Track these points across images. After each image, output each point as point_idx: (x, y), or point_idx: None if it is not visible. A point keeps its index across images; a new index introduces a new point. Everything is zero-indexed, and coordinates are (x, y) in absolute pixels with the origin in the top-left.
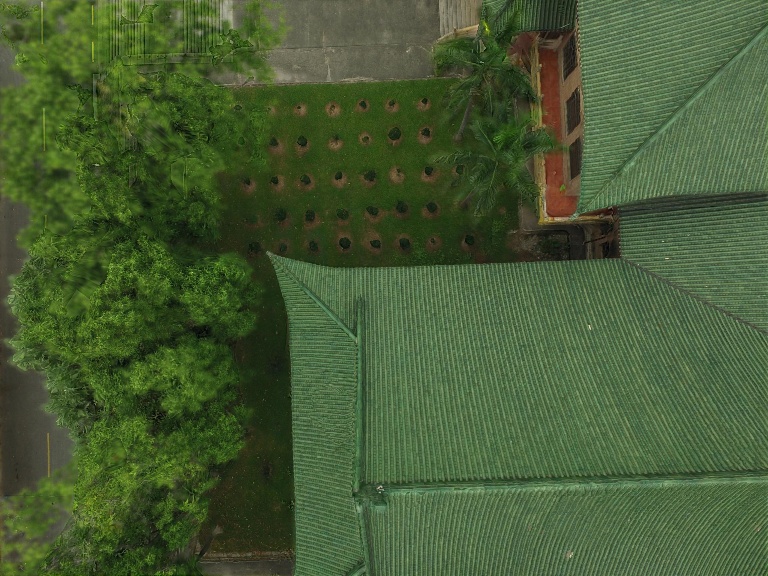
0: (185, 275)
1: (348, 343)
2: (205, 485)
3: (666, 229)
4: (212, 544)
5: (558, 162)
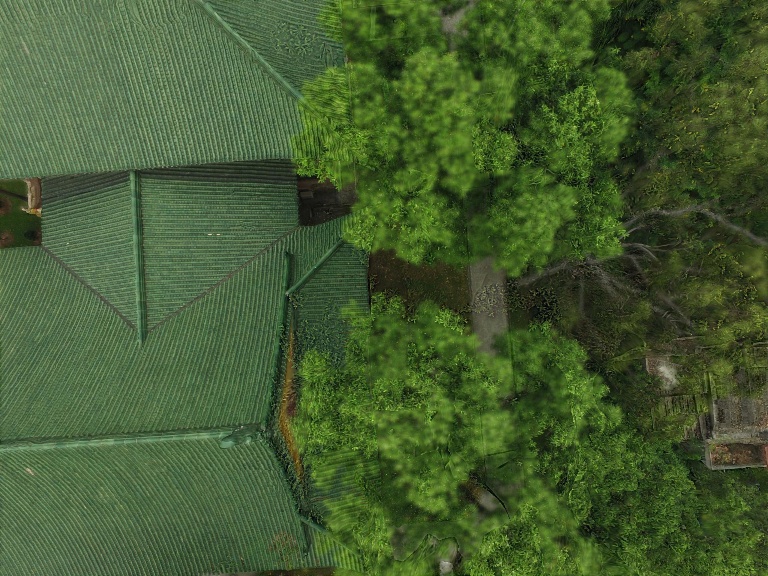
0: None
1: None
2: None
3: (67, 215)
4: None
5: None
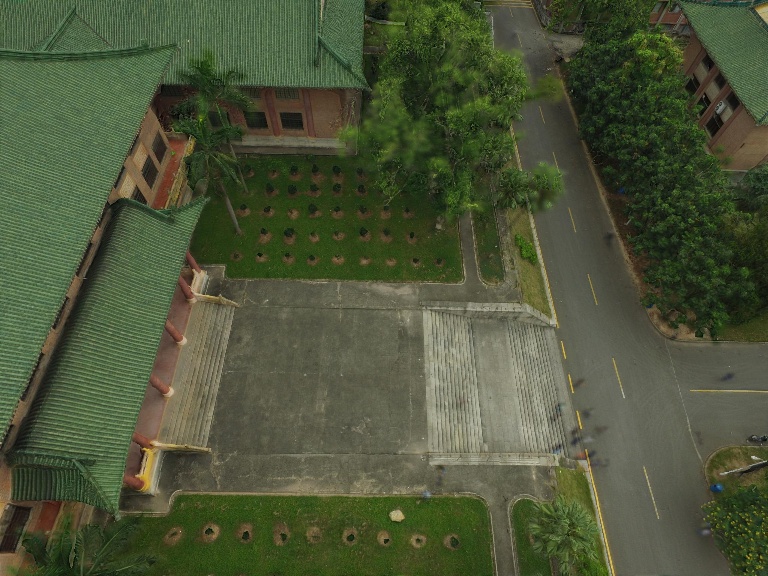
0: (410, 50)
1: None
2: (408, 12)
3: None
4: None
5: (171, 166)
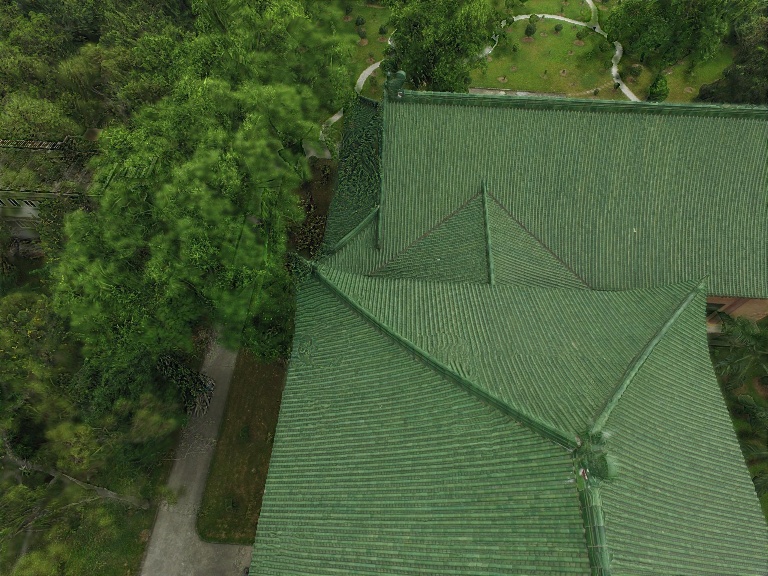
0: None
1: None
2: None
3: None
4: None
5: None
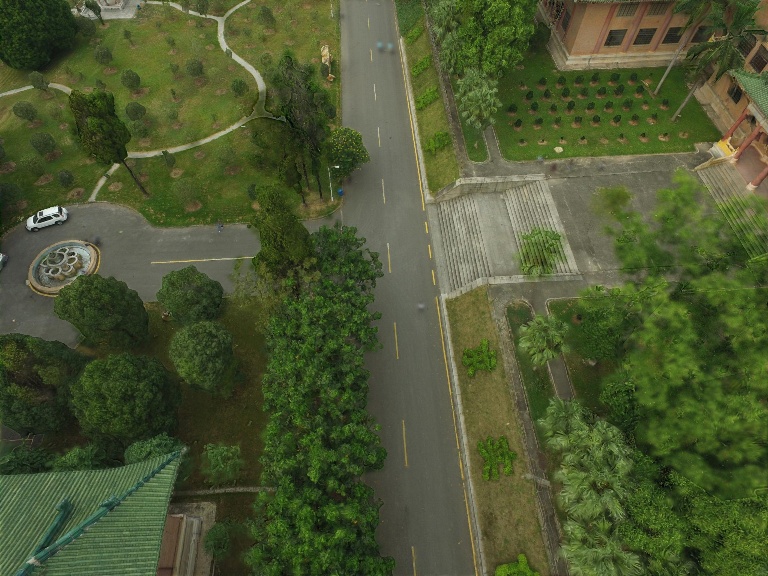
0: None
1: None
2: None
3: None
4: None
5: None
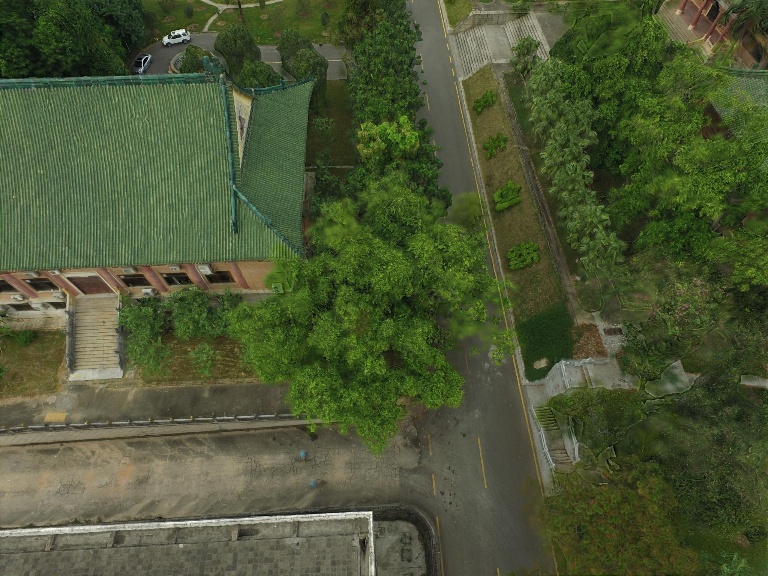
0: None
1: (760, 83)
2: None
3: None
4: (637, 296)
5: None
